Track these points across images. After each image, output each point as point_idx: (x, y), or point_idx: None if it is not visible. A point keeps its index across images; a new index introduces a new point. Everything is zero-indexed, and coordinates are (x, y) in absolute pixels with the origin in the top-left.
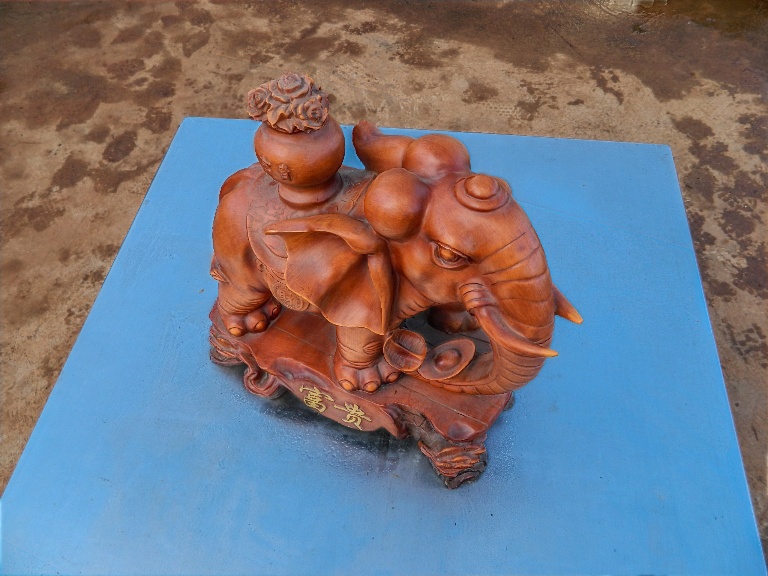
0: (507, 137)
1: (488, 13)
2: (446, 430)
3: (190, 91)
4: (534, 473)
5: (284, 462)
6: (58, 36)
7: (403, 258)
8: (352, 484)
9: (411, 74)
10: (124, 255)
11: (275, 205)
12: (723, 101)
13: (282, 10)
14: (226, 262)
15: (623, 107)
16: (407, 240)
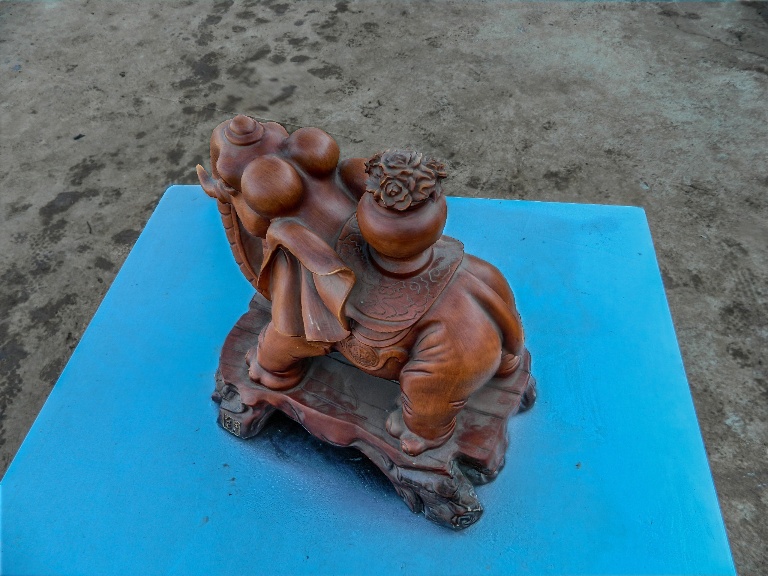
0: None
1: None
2: None
3: None
4: None
5: None
6: None
7: None
8: None
9: None
10: (713, 526)
11: None
12: None
13: None
14: None
15: None
16: None
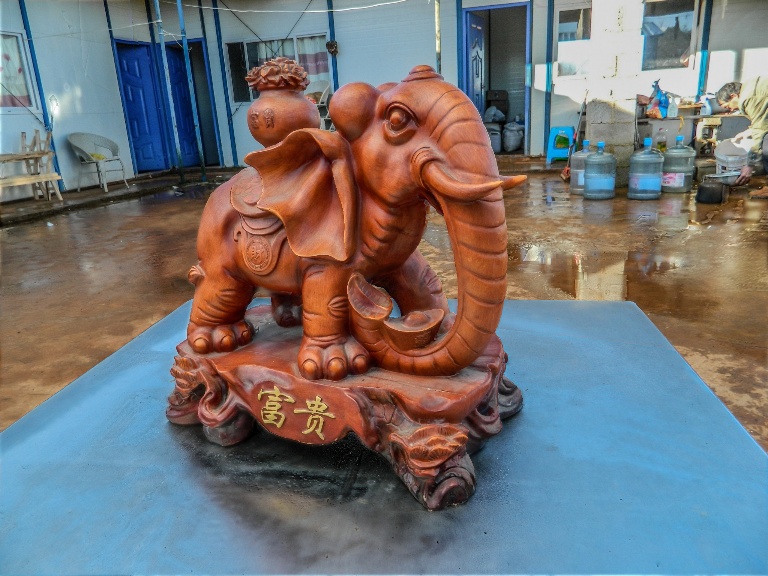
0: None
1: None
2: (418, 400)
3: None
4: (536, 496)
5: (226, 493)
6: (97, 329)
7: (362, 151)
8: (307, 509)
9: None
10: (104, 364)
11: (258, 176)
12: (698, 359)
13: None
14: (206, 245)
15: None
16: (365, 130)
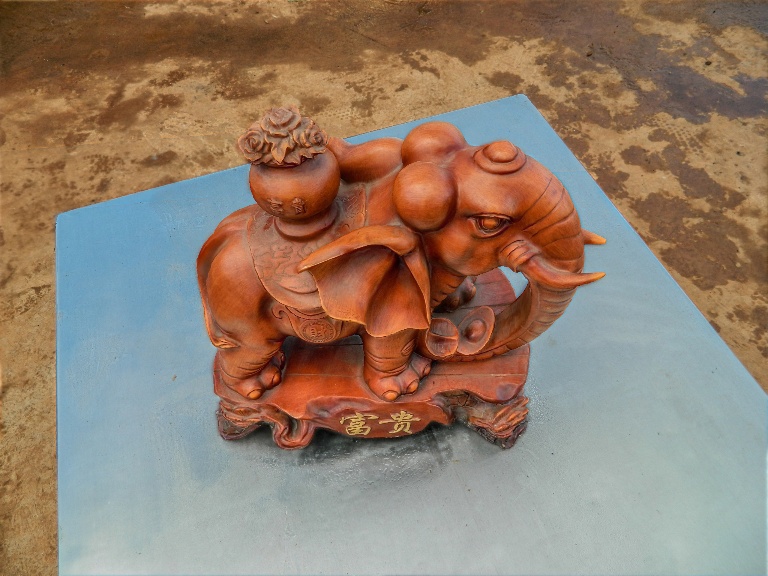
0: (390, 129)
1: (286, 32)
2: (495, 395)
3: (10, 196)
4: (566, 402)
5: (349, 500)
6: None
7: (441, 244)
8: (422, 488)
9: (240, 108)
10: (65, 378)
11: (280, 246)
12: (517, 51)
13: (75, 84)
14: (237, 325)
15: (442, 80)
16: (444, 225)
